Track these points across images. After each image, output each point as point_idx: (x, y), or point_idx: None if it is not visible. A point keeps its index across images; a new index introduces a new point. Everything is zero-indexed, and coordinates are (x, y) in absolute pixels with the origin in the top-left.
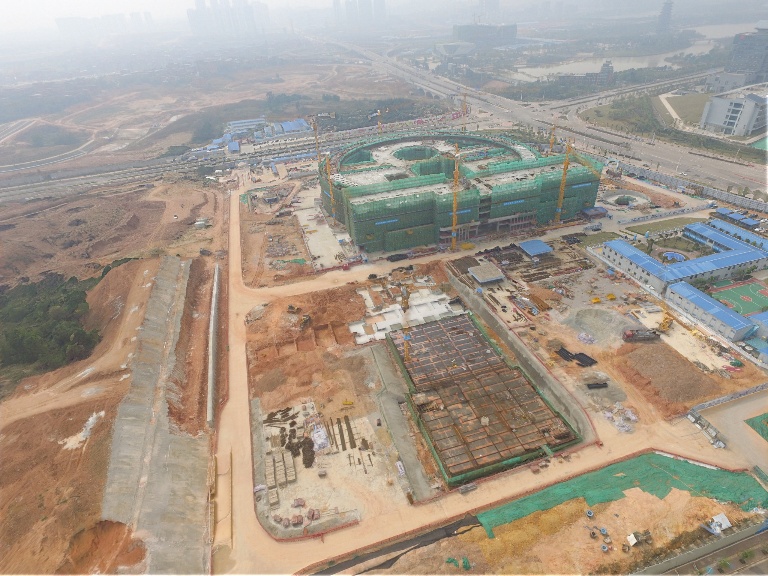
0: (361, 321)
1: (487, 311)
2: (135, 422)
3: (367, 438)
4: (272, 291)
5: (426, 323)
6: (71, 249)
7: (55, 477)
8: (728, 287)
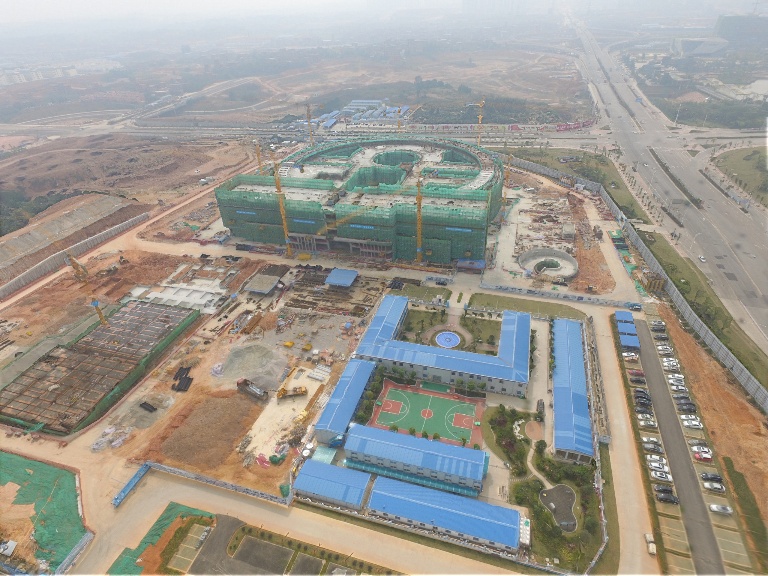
0: (148, 286)
1: None
2: None
3: None
4: (140, 243)
5: (161, 304)
6: (109, 178)
7: None
8: (434, 393)
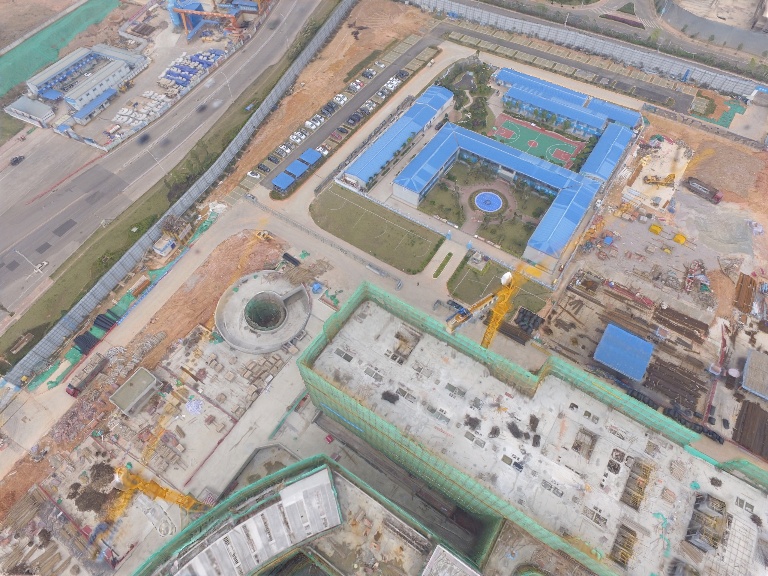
0: None
1: None
2: None
3: None
4: None
5: None
6: None
7: None
8: None
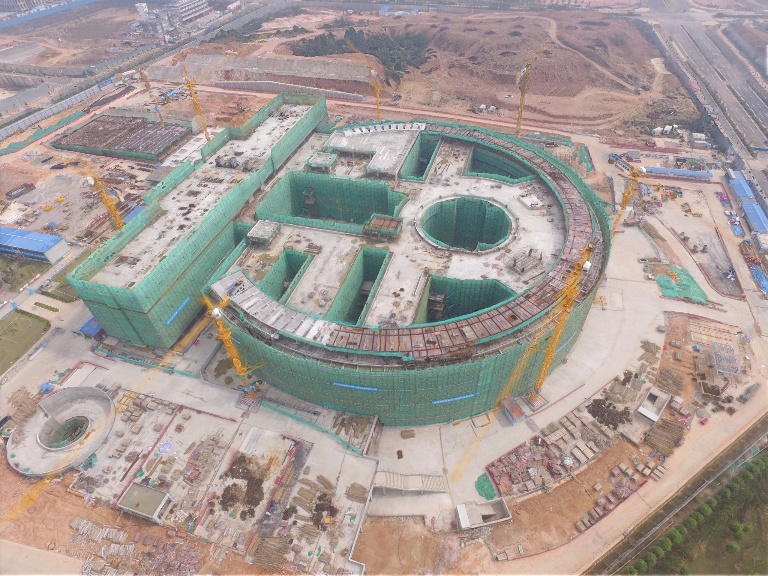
0: None
1: None
2: (224, 61)
3: (147, 106)
4: None
5: (174, 139)
6: None
7: (215, 48)
8: None
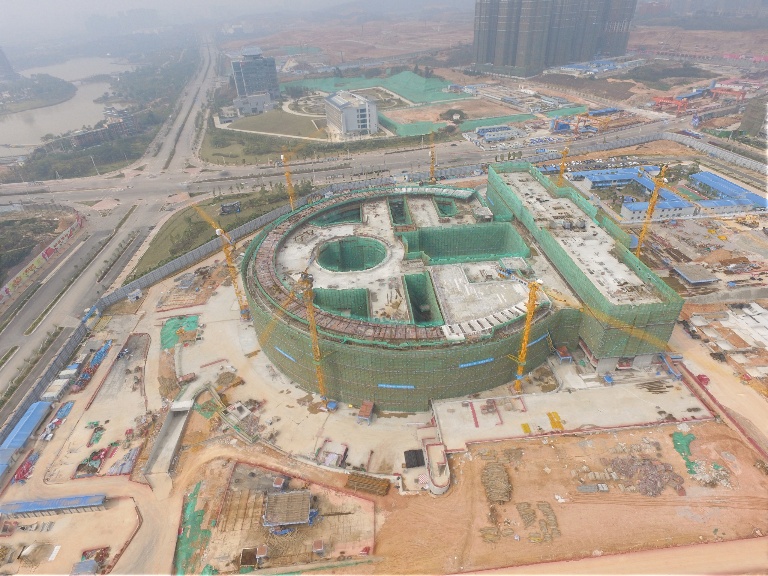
0: None
1: (765, 288)
2: None
3: None
4: None
5: None
6: None
7: None
8: None
